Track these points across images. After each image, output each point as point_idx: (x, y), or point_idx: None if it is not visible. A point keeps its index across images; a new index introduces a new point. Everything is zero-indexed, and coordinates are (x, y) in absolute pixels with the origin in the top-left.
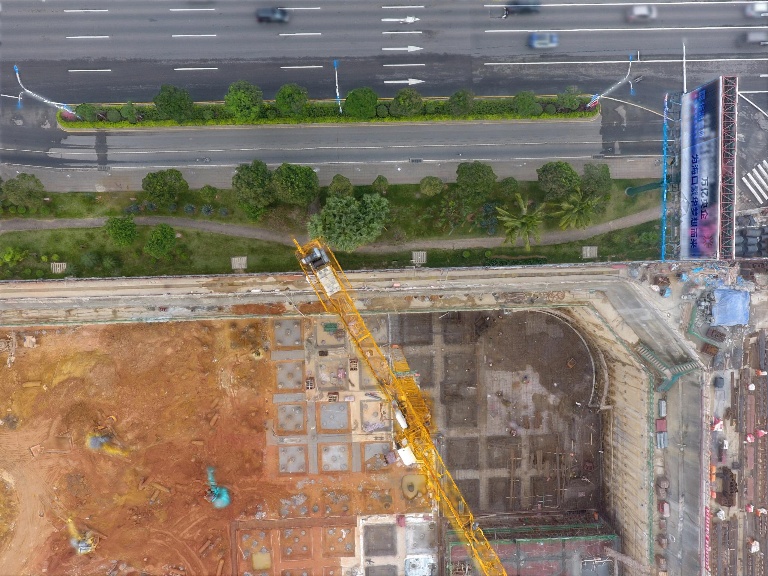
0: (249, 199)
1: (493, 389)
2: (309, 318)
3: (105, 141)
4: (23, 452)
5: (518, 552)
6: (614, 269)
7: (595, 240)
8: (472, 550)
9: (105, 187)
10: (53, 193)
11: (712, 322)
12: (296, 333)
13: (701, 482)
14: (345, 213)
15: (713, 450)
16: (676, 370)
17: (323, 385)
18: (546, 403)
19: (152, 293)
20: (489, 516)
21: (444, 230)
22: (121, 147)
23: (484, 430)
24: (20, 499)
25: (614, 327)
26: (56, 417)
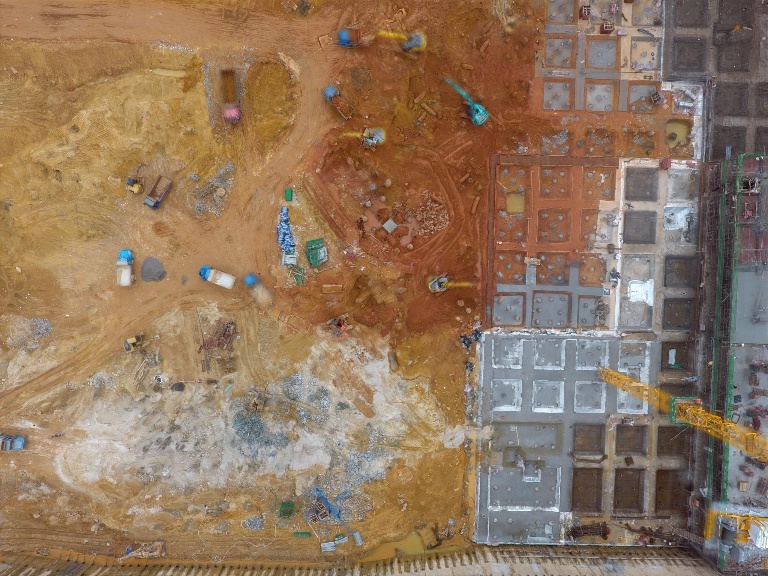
0: None
1: (767, 34)
2: None
3: None
4: (311, 42)
5: None
6: None
7: None
8: (760, 166)
9: None
10: None
11: None
12: None
13: None
14: None
15: None
16: None
17: (594, 21)
18: None
19: None
20: None
21: None
22: None
23: (755, 76)
24: (303, 91)
25: None
26: (346, 8)
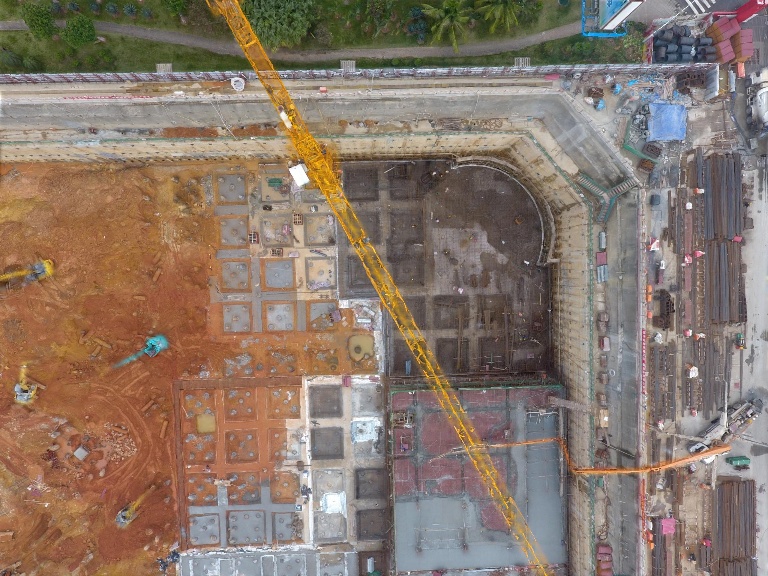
0: None
1: (440, 247)
2: (253, 172)
3: None
4: None
5: (461, 402)
6: (547, 81)
7: (528, 51)
8: (414, 399)
9: None
10: None
11: (647, 135)
12: (240, 188)
13: (638, 305)
14: None
15: (650, 272)
16: (613, 193)
17: (268, 242)
18: (494, 262)
19: None
20: None
21: (373, 38)
22: None
23: (431, 289)
24: None
25: (553, 157)
26: None
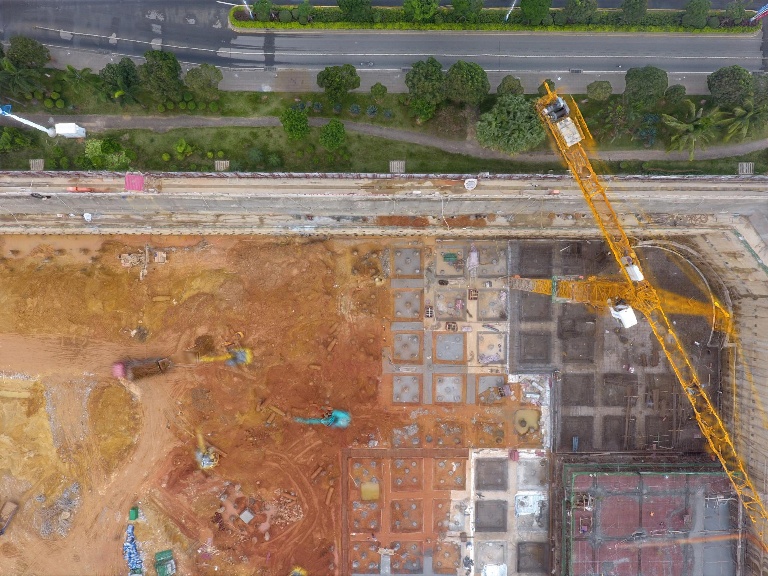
0: (424, 95)
1: (611, 325)
2: (430, 247)
3: (273, 42)
4: (151, 365)
5: (641, 485)
6: None
7: (752, 156)
8: (594, 481)
9: (271, 87)
10: (221, 91)
11: None
12: (416, 262)
13: None
14: (519, 111)
15: None
16: None
17: (440, 315)
18: None
19: (312, 193)
20: (603, 454)
21: (601, 141)
22: (288, 49)
23: (600, 367)
24: (145, 412)
25: (756, 253)
26: (185, 331)
